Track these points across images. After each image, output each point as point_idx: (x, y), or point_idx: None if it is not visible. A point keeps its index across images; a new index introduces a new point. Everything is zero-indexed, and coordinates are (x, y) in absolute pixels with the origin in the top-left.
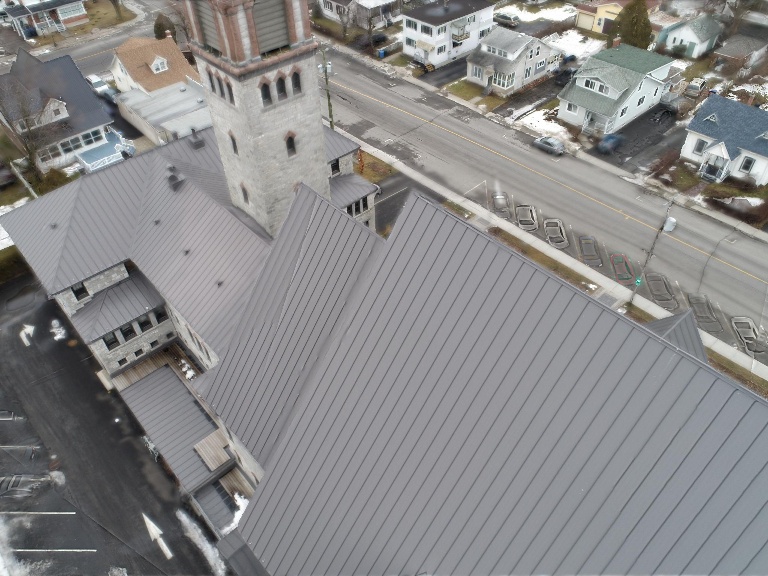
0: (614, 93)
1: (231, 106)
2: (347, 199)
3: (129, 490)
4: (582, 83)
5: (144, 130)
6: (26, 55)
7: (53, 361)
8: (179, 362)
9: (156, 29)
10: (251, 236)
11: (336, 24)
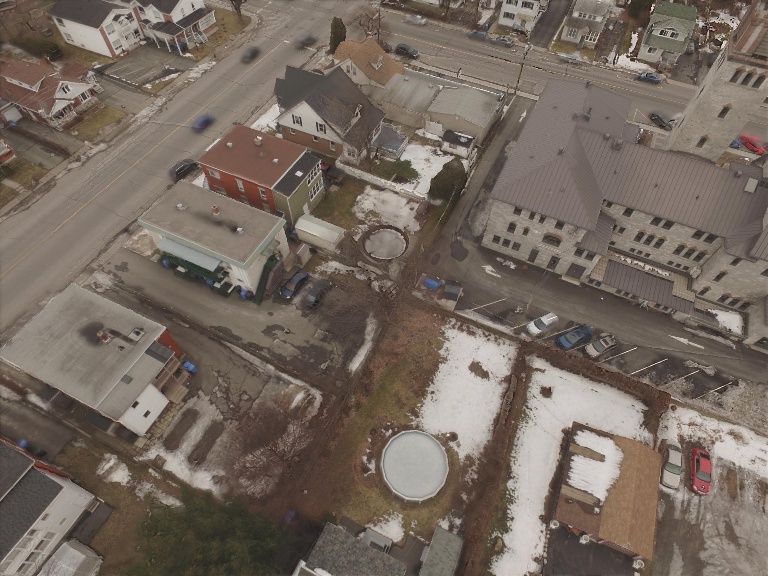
0: (683, 37)
1: (753, 89)
2: (634, 136)
3: (650, 328)
4: (658, 33)
5: (396, 117)
6: (303, 71)
7: (528, 280)
8: (615, 256)
9: (334, 31)
10: (705, 166)
11: (425, 5)
